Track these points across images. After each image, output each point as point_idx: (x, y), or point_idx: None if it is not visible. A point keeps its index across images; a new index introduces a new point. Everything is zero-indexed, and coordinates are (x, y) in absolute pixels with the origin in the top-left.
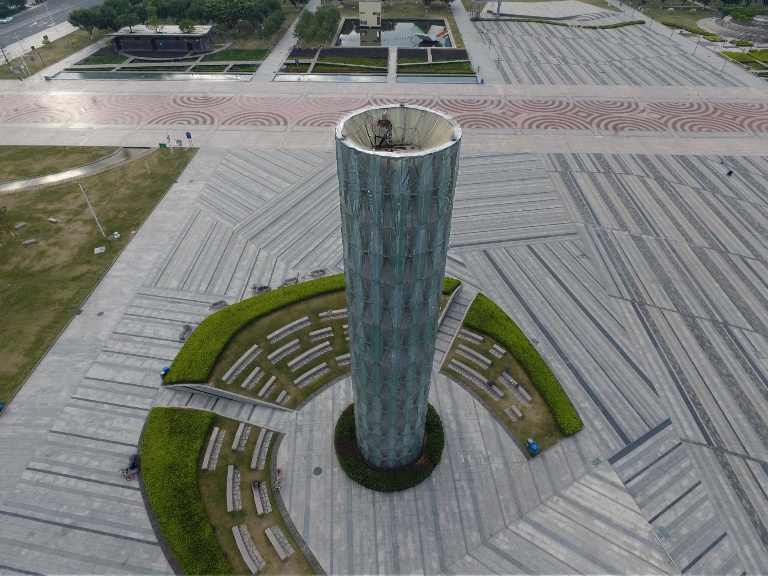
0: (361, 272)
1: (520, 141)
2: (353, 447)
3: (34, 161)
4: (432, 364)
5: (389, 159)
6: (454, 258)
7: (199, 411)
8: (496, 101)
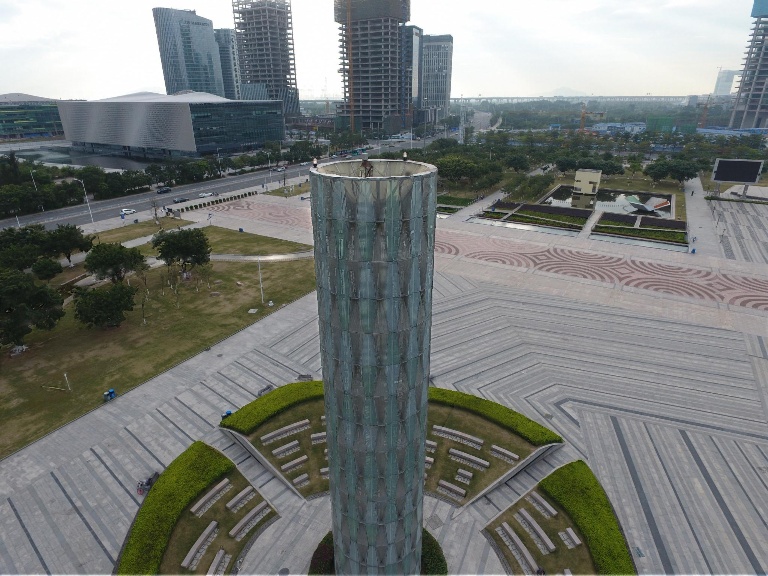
0: (320, 312)
1: (721, 316)
2: (331, 565)
3: (257, 245)
4: (413, 476)
5: (331, 180)
6: (568, 412)
7: (223, 457)
8: (704, 272)
